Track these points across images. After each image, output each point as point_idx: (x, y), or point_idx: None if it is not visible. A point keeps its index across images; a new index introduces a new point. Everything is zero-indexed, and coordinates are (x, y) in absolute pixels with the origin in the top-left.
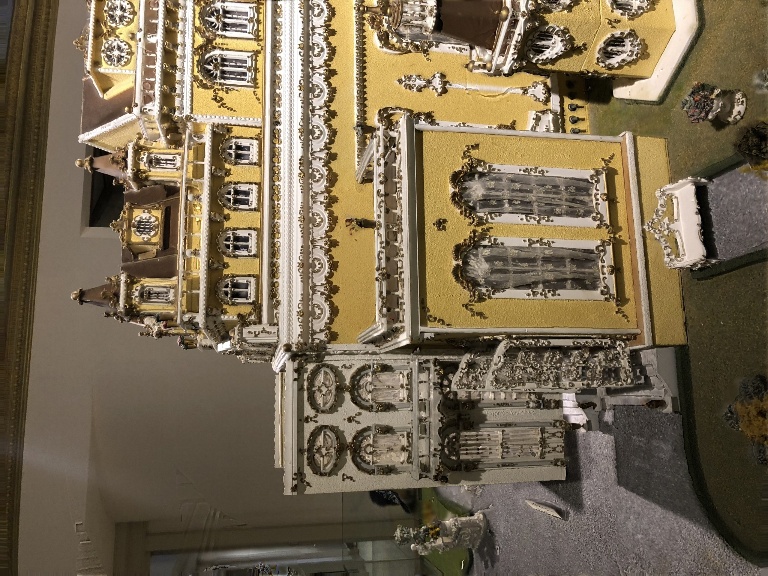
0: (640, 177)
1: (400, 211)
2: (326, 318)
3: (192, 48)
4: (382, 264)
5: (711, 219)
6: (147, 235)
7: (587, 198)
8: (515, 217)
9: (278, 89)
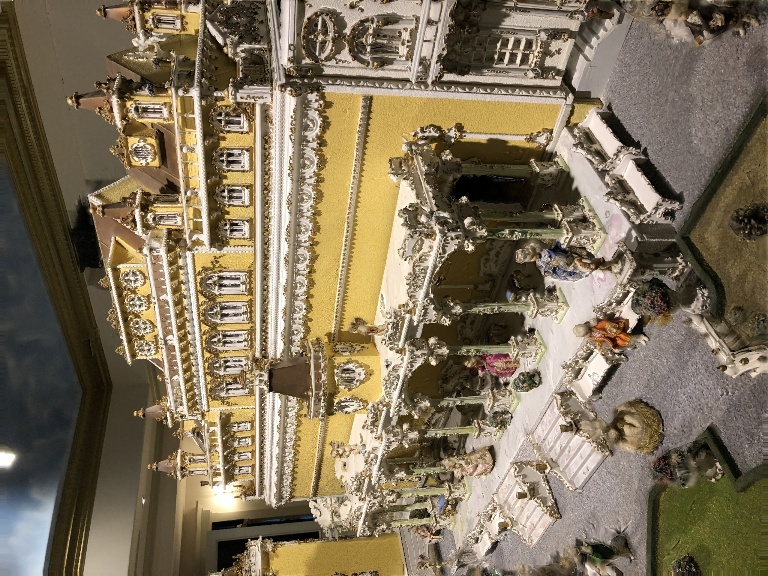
0: None
1: None
2: None
3: None
4: None
5: None
6: None
7: None
8: None
9: None
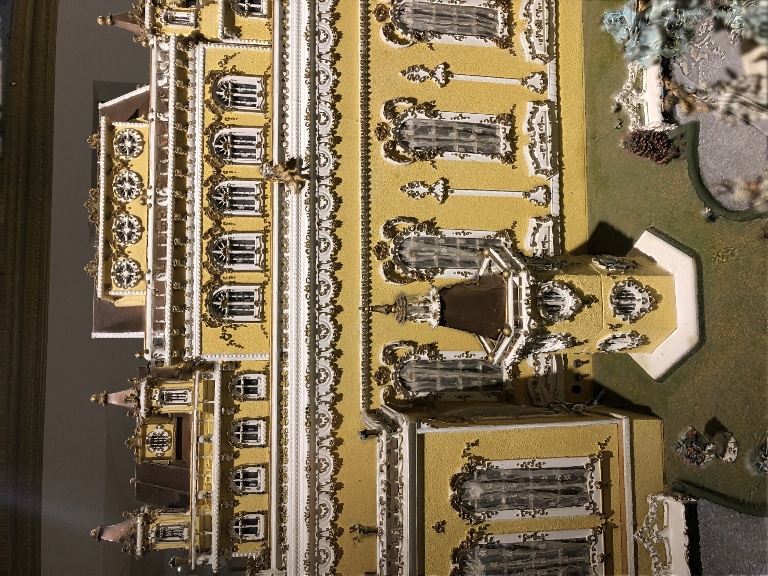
0: (634, 463)
1: (401, 518)
2: (331, 562)
3: (200, 285)
4: (383, 571)
5: (698, 532)
6: (160, 451)
7: (582, 485)
8: (511, 513)
9: (285, 329)
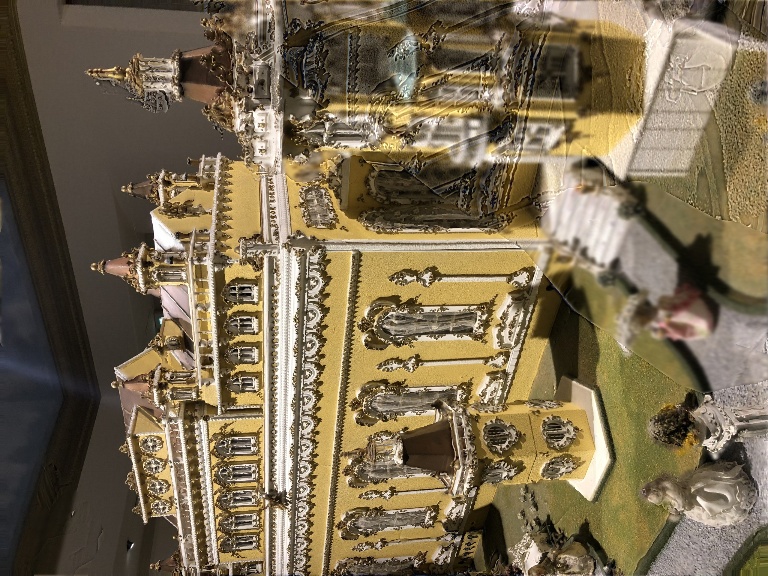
0: None
1: None
2: None
3: (216, 537)
4: None
5: None
6: None
7: None
8: None
9: (273, 558)
